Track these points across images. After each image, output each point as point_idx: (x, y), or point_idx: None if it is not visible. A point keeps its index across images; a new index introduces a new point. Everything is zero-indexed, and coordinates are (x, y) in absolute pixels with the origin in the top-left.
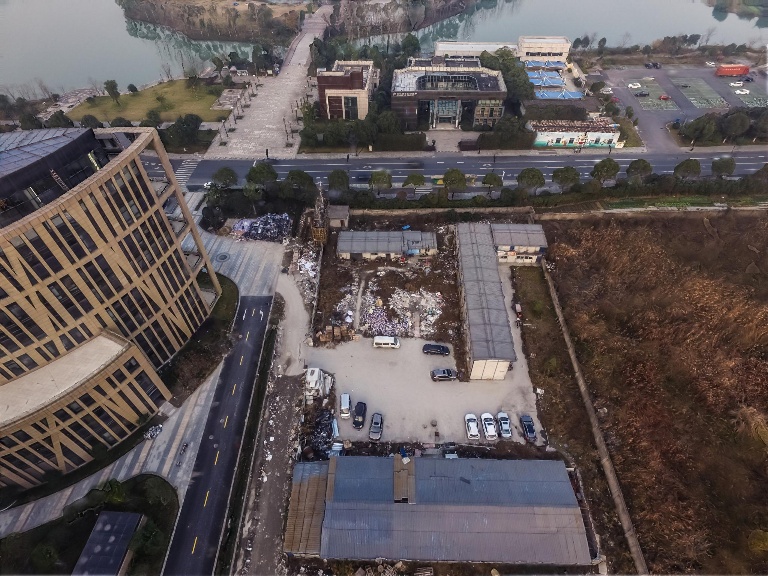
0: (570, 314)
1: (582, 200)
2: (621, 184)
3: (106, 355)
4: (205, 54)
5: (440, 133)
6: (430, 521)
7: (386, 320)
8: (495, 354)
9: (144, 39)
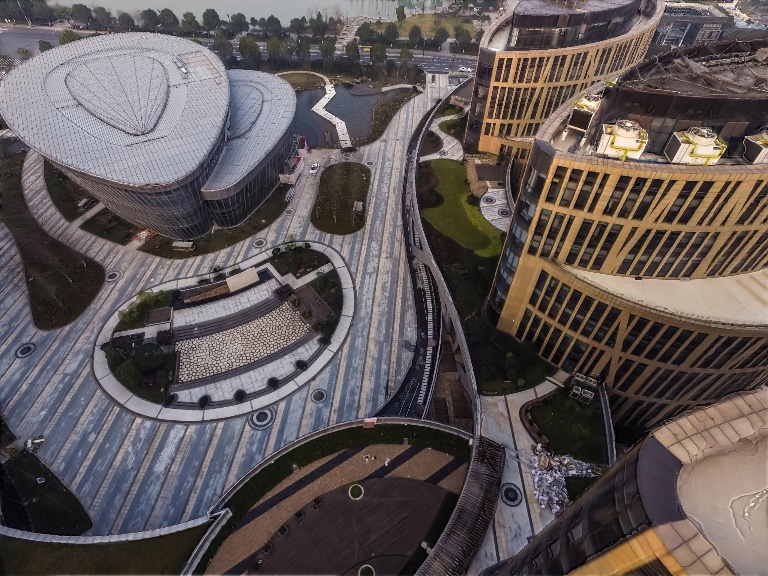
0: None
1: None
2: None
3: None
4: (403, 2)
5: None
6: None
7: None
8: None
9: None
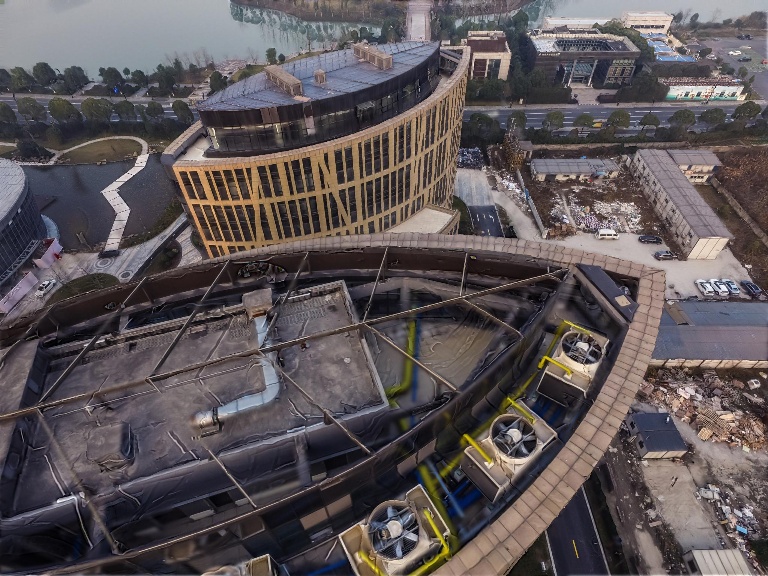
0: (755, 214)
1: (726, 138)
2: (760, 124)
3: (440, 219)
4: (312, 35)
5: (575, 90)
6: (710, 336)
7: (598, 221)
8: (716, 233)
9: (249, 23)
